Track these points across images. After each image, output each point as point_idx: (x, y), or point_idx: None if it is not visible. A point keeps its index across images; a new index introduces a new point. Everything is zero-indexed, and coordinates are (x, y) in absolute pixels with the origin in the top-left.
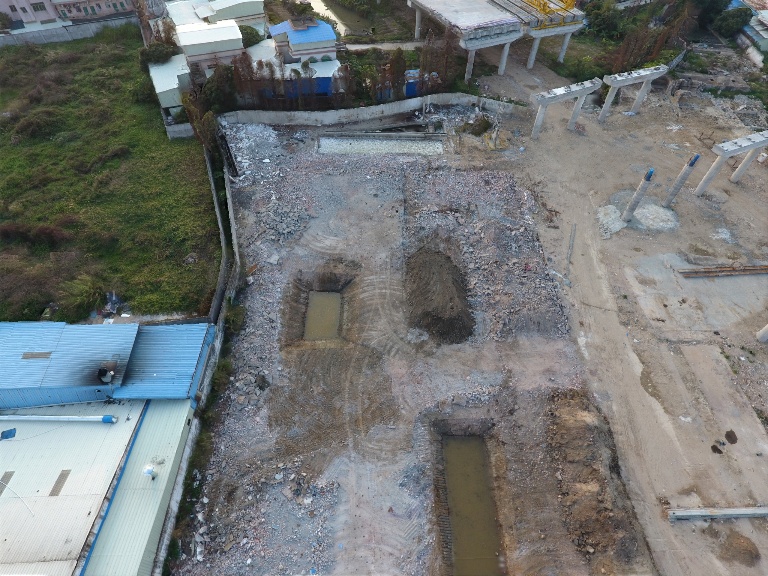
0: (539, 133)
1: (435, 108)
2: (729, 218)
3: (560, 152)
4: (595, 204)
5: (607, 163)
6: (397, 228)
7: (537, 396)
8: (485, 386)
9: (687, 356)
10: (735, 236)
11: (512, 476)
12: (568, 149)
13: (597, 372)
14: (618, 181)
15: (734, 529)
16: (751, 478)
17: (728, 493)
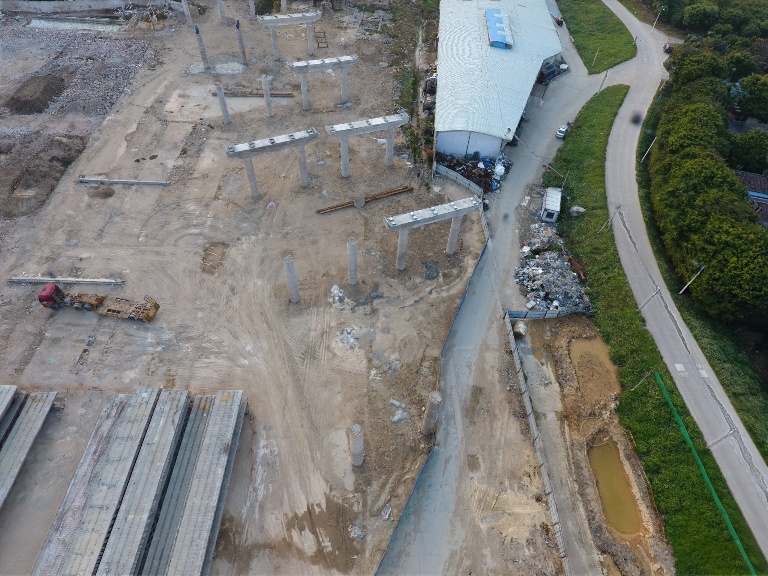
0: (198, 23)
1: (134, 7)
2: (282, 71)
3: (202, 34)
4: (195, 61)
5: (229, 41)
6: (41, 64)
7: (52, 137)
8: (24, 131)
9: (169, 127)
10: (274, 80)
11: (2, 164)
12: (209, 33)
13: (103, 130)
14: (226, 50)
15: (110, 187)
16: (145, 171)
17: (123, 175)
